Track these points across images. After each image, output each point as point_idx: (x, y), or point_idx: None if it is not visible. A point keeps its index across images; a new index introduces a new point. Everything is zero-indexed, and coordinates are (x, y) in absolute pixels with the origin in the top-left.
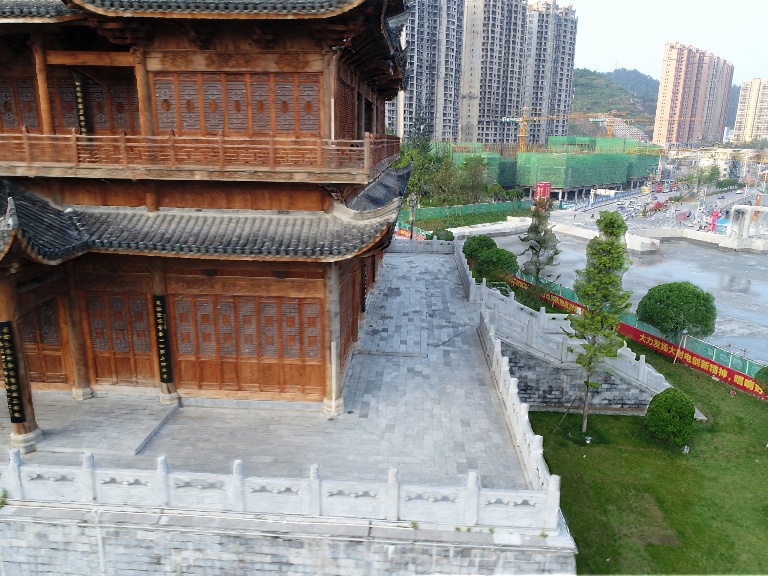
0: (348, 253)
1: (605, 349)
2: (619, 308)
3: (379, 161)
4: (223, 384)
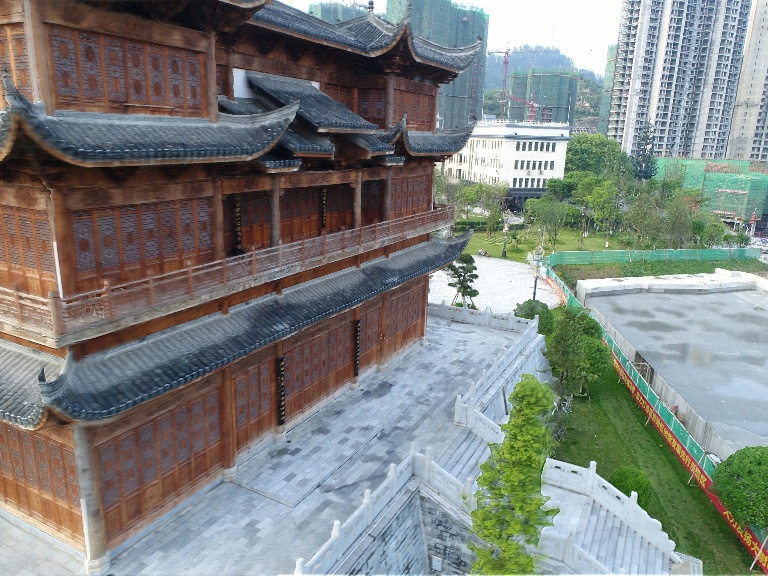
0: (28, 426)
1: (504, 565)
2: (541, 511)
3: (210, 286)
4: (20, 505)
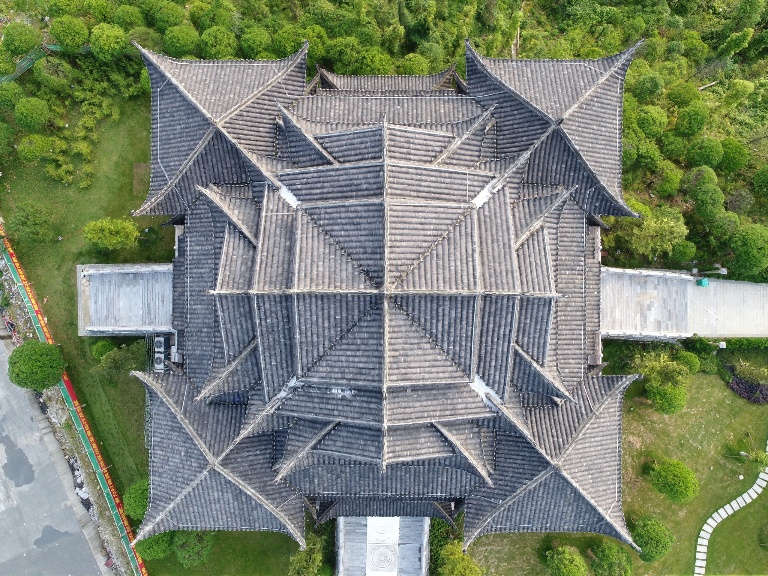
0: None
1: None
2: None
3: None
4: None
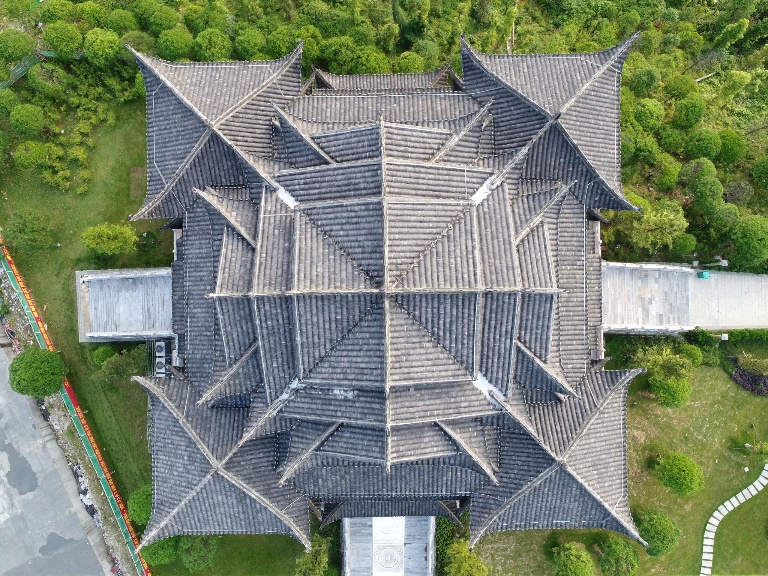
0: None
1: None
2: None
3: None
4: None
